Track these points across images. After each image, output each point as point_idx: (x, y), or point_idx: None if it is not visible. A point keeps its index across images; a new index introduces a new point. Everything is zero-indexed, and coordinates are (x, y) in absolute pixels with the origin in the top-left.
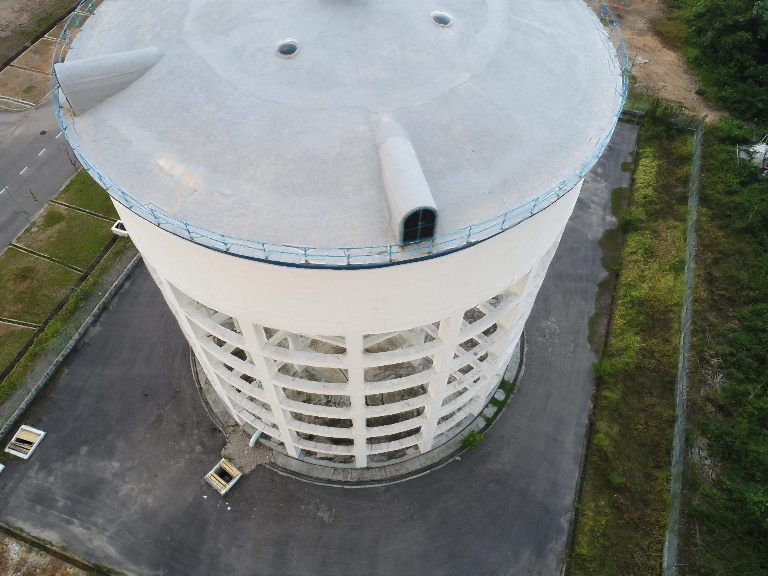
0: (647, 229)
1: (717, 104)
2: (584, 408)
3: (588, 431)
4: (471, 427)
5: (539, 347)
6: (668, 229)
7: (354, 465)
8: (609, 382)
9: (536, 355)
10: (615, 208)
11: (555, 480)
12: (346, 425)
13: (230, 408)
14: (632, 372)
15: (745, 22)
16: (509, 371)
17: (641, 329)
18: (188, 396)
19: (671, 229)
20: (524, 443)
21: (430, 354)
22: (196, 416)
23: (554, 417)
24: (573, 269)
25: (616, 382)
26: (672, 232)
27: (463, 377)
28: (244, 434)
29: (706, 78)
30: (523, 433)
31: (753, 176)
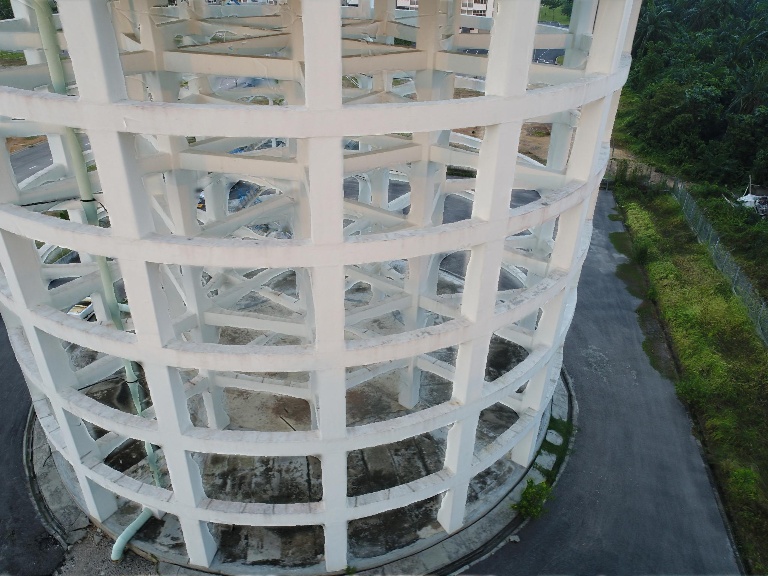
0: (666, 261)
1: (681, 177)
2: (689, 446)
3: (712, 477)
4: (523, 486)
5: (588, 377)
6: (690, 262)
7: (322, 568)
8: (708, 409)
9: (588, 387)
10: (619, 247)
11: (697, 558)
12: (302, 502)
13: (76, 471)
14: (734, 396)
15: (681, 108)
16: (557, 406)
17: (716, 349)
18: (5, 490)
19: (693, 262)
20: (619, 504)
21: (477, 121)
22: (12, 520)
23: (650, 462)
24: (596, 299)
25: (718, 410)
26: (696, 263)
27: (518, 296)
28: (104, 541)
29: (660, 161)
30: (611, 489)
31: (754, 217)
